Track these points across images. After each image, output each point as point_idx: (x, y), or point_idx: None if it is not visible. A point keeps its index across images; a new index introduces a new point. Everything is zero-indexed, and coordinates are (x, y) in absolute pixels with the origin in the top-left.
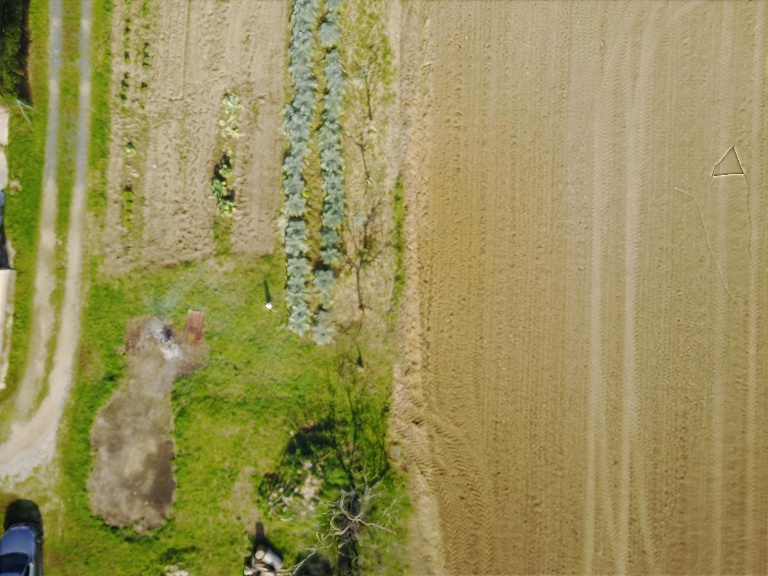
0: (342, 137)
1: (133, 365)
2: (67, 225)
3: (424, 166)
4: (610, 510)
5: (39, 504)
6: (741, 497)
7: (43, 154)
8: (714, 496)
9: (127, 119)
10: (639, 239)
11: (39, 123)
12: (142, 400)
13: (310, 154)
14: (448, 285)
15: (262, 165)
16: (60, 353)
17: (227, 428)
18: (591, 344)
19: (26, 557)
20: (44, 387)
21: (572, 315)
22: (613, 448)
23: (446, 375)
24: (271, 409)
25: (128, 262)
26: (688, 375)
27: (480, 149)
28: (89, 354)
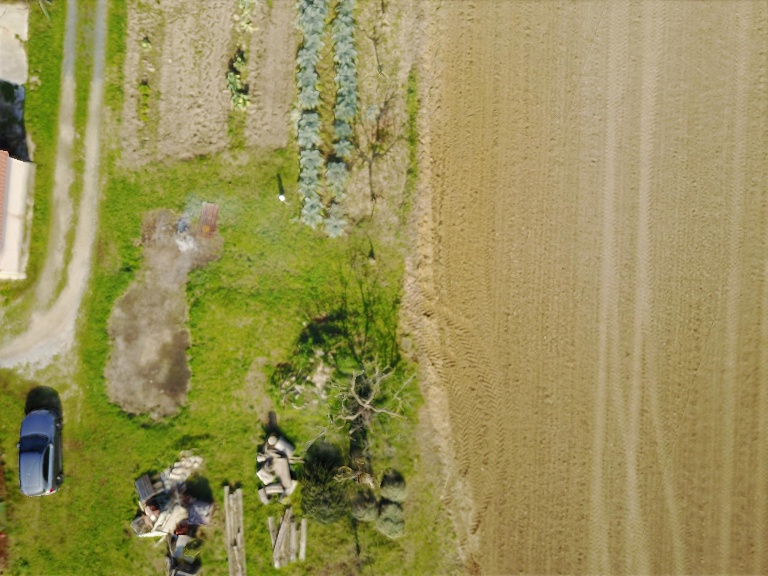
0: (355, 31)
1: (149, 256)
2: (85, 119)
3: (437, 60)
4: (622, 402)
5: (59, 390)
6: (756, 389)
7: (61, 49)
8: (728, 388)
9: (143, 14)
10: (654, 130)
11: (57, 18)
12: (158, 290)
13: (323, 47)
14: (460, 178)
15: (275, 59)
16: (78, 244)
17: (241, 318)
18: (604, 236)
19: (46, 438)
20: (63, 277)
21: (585, 207)
22: (625, 340)
23: (458, 268)
24: (284, 300)
25: (144, 155)
26: (703, 266)
27: (493, 42)
28: (106, 245)
